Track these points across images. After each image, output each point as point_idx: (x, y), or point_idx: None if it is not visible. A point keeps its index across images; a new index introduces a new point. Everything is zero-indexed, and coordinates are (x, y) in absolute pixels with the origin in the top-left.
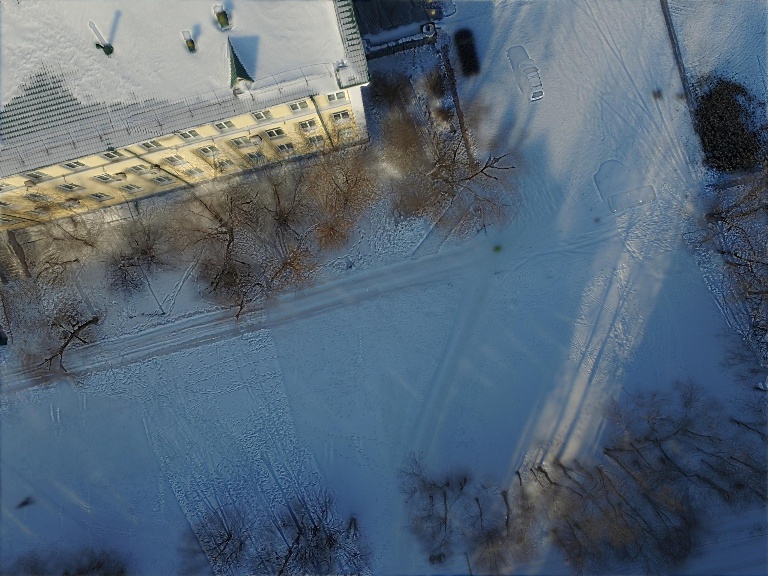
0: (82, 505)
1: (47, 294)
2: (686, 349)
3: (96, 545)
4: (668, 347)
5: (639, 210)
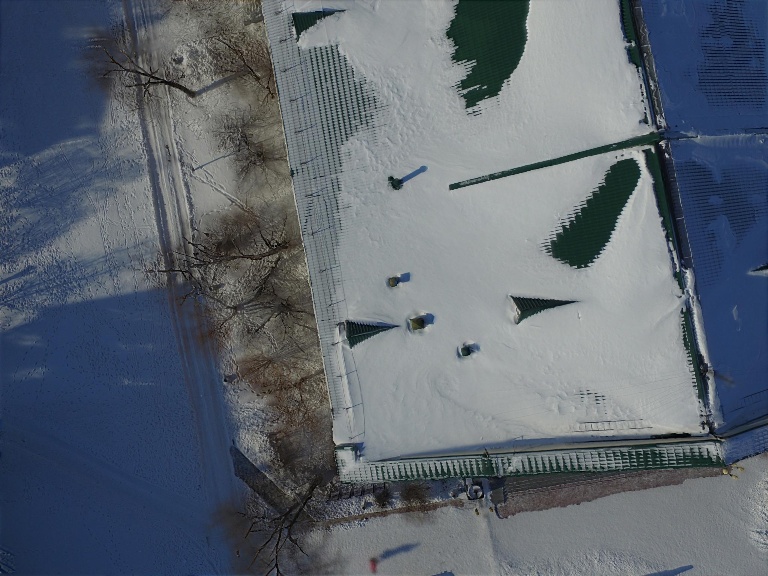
0: None
1: None
2: None
3: None
4: None
5: None
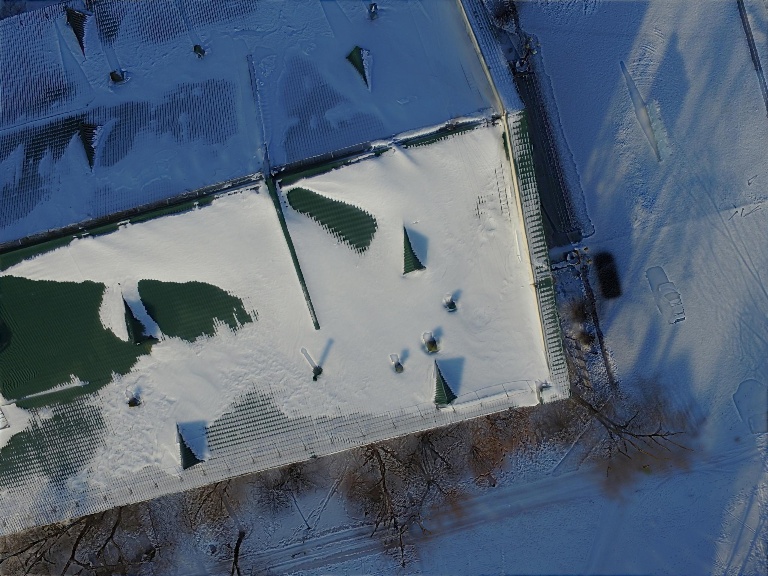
0: None
1: (194, 509)
2: None
3: None
4: None
5: None
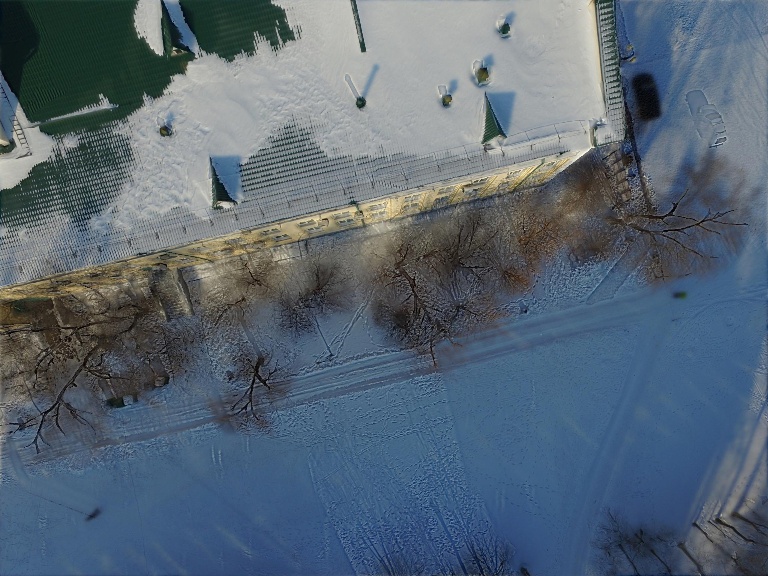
0: (243, 550)
1: (212, 333)
2: None
3: None
4: None
5: None
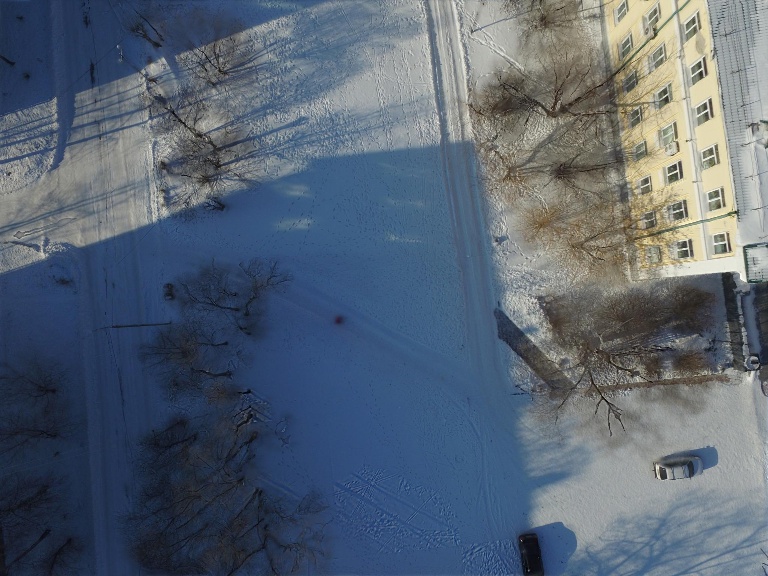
0: None
1: None
2: None
3: None
4: (363, 575)
5: (517, 567)
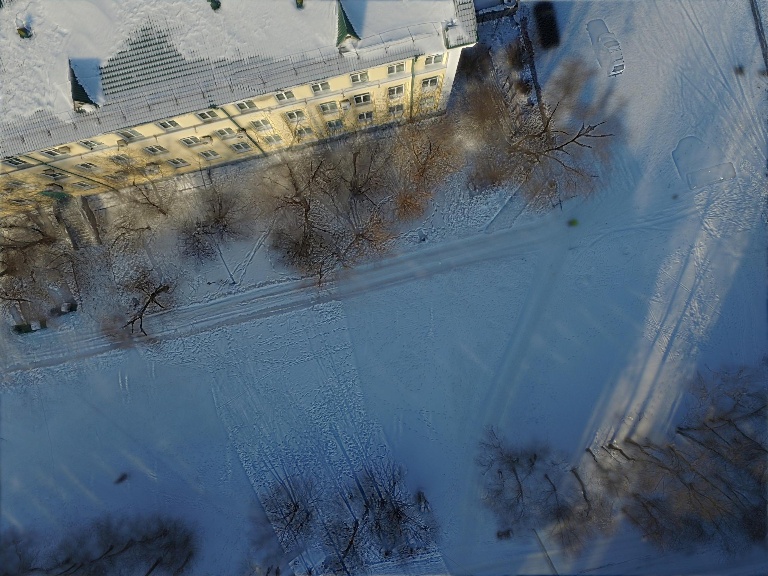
0: (149, 473)
1: (118, 261)
2: (763, 329)
3: (163, 513)
4: (744, 327)
5: (718, 188)
